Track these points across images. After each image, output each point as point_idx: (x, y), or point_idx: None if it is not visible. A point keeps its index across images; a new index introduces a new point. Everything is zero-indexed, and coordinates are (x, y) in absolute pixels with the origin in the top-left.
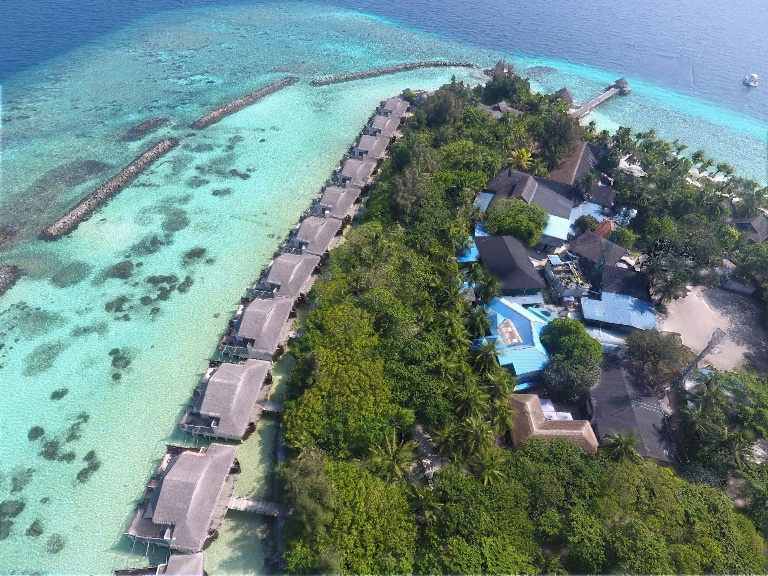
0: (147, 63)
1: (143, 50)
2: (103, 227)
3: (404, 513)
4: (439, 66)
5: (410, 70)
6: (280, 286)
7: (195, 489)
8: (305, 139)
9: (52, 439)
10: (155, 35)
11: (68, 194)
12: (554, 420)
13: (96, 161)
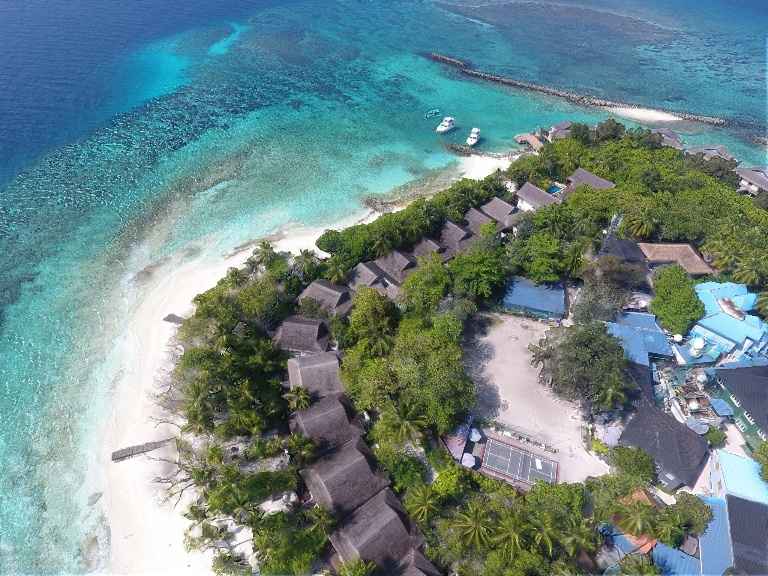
0: None
1: None
2: None
3: None
4: None
5: None
6: None
7: None
8: None
9: None
10: None
11: None
12: (673, 258)
13: None
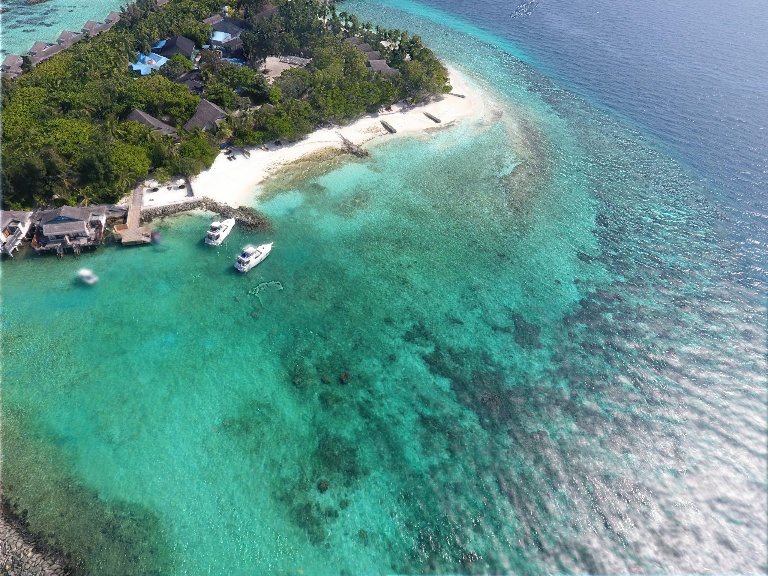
0: None
1: None
2: None
3: (44, 92)
4: None
5: None
6: (37, 53)
7: None
8: (102, 11)
9: None
10: None
11: None
12: None
13: None
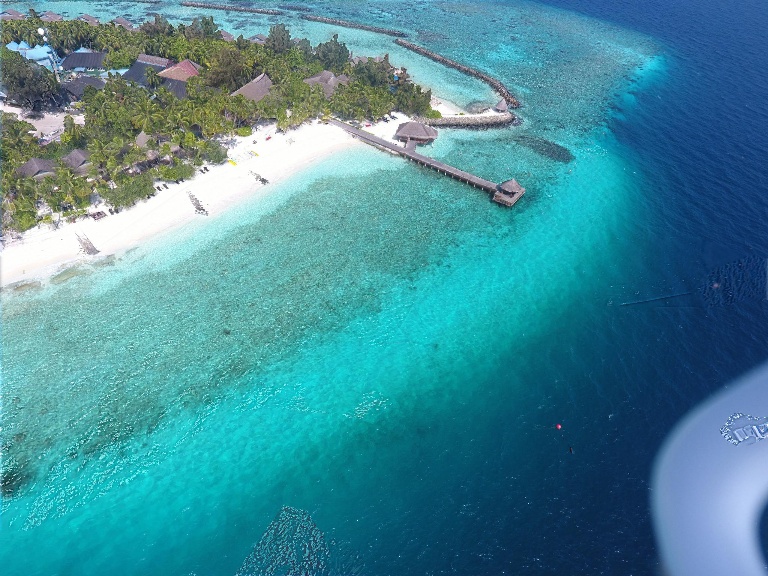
0: (403, 3)
1: (428, 1)
2: None
3: None
4: (493, 87)
5: (467, 74)
6: None
7: (6, 15)
8: None
9: (61, 14)
10: (464, 1)
11: (220, 3)
12: None
13: (253, 4)
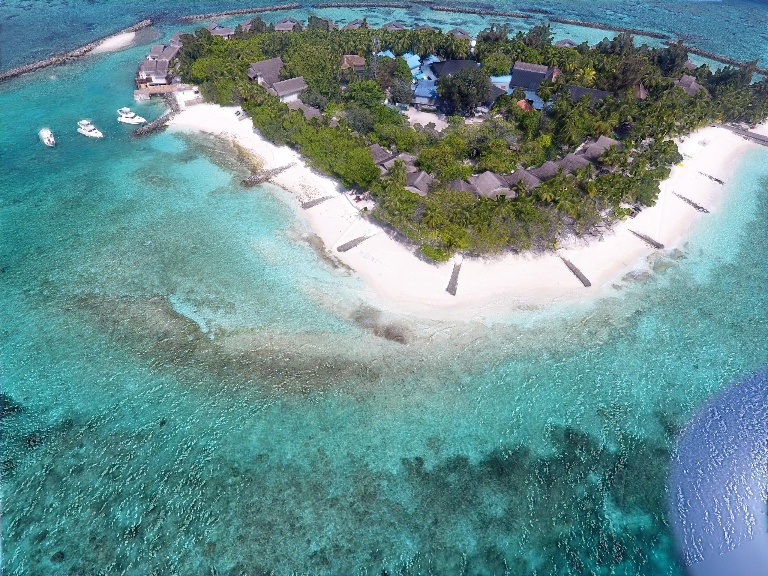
0: (624, 3)
1: (643, 1)
2: (444, 14)
3: None
4: None
5: (767, 76)
6: None
7: None
8: None
9: (342, 21)
10: (676, 0)
11: (463, 7)
12: None
13: (494, 7)
